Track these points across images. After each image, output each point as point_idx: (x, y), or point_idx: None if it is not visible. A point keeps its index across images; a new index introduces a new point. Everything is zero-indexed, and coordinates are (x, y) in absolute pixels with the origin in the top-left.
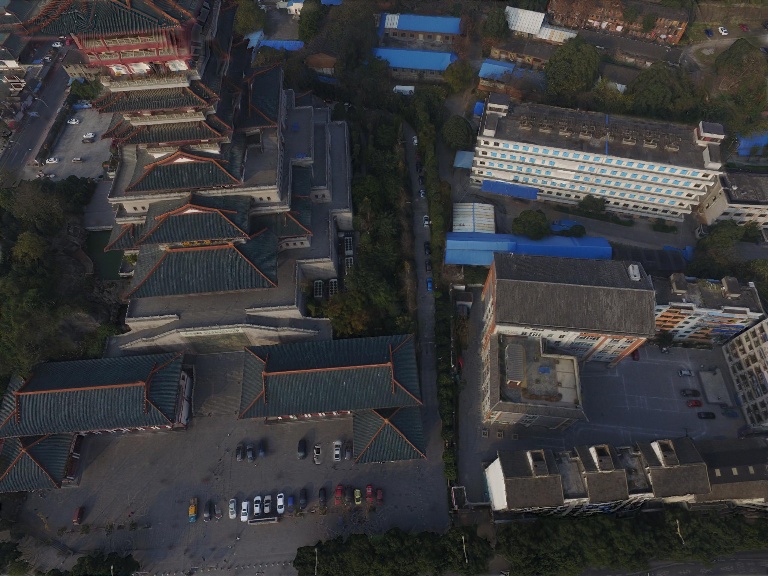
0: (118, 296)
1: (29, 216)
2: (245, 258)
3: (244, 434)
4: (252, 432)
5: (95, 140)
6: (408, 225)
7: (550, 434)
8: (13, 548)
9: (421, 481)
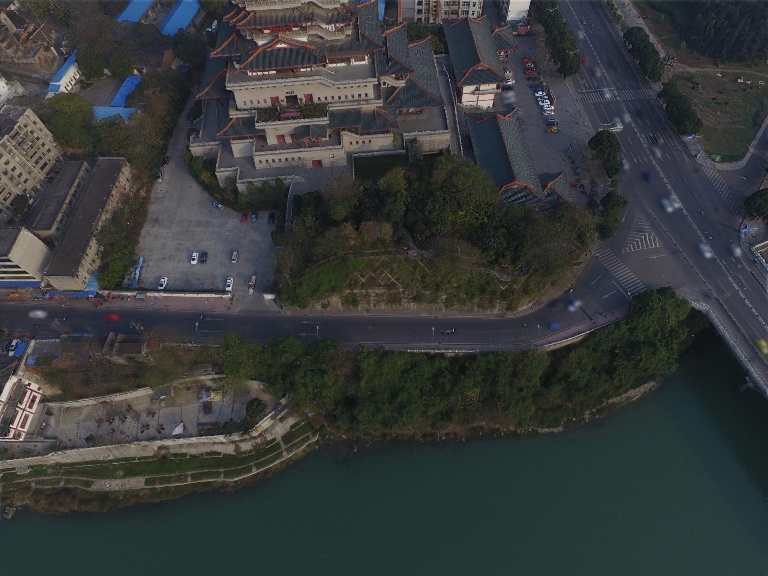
0: None
1: None
2: (412, 44)
3: None
4: None
5: None
6: None
7: (482, 6)
8: None
9: None
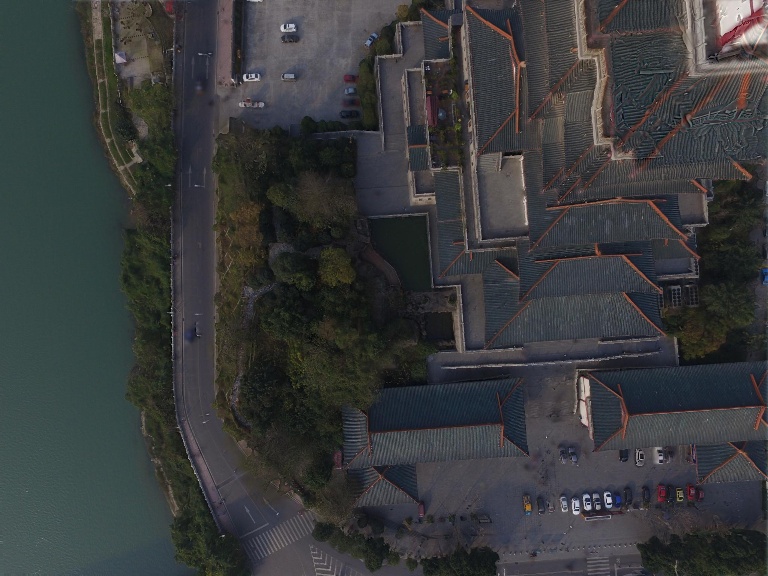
0: (431, 310)
1: (320, 221)
2: (631, 302)
3: (562, 437)
4: (570, 435)
5: (299, 36)
6: (756, 200)
7: None
8: (382, 543)
9: (737, 481)
